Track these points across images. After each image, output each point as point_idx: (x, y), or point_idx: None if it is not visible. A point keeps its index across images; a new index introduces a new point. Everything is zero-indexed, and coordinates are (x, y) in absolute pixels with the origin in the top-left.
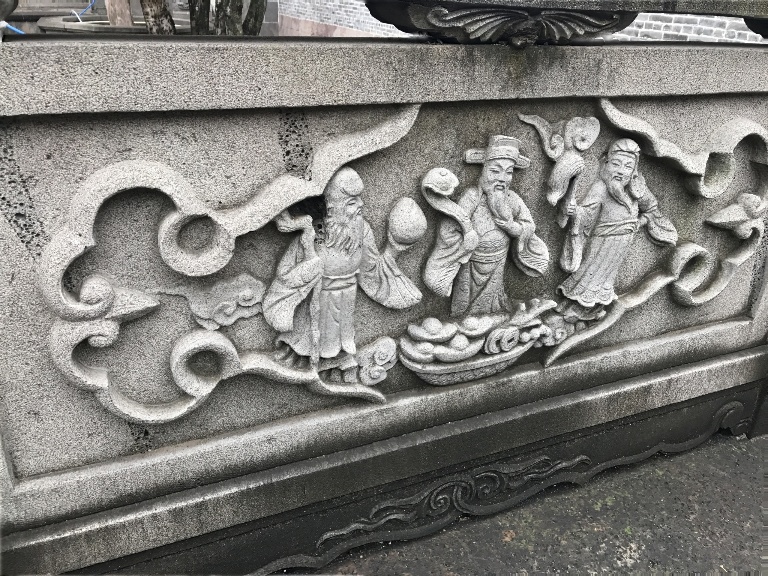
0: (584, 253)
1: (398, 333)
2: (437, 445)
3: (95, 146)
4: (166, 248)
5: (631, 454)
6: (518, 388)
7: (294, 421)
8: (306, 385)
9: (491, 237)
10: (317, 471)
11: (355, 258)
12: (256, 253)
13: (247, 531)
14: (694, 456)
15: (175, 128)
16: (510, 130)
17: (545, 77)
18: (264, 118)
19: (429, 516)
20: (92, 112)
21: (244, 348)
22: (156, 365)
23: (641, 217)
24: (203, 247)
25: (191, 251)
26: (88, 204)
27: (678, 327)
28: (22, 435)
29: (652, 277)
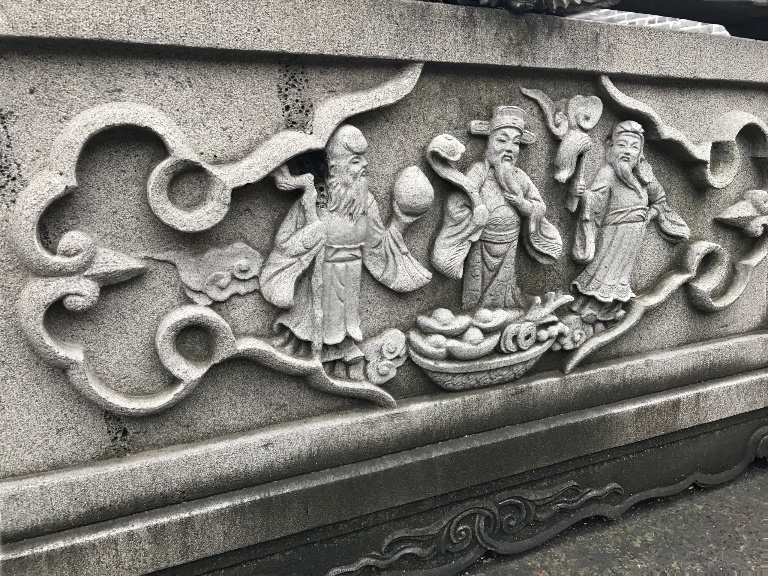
0: (596, 245)
1: (407, 326)
2: (455, 459)
3: (83, 83)
4: (156, 195)
5: (665, 484)
6: (538, 397)
7: (294, 425)
8: (308, 378)
9: (501, 213)
10: (321, 484)
11: (360, 226)
12: (253, 219)
13: (240, 562)
14: (733, 489)
15: (169, 70)
16: (513, 104)
17: (545, 46)
18: (263, 68)
19: (449, 553)
20: (81, 38)
21: (239, 332)
22: (139, 346)
23: (651, 209)
24: (196, 205)
25: (183, 208)
26: (72, 140)
27: (699, 338)
28: None
29: (668, 276)
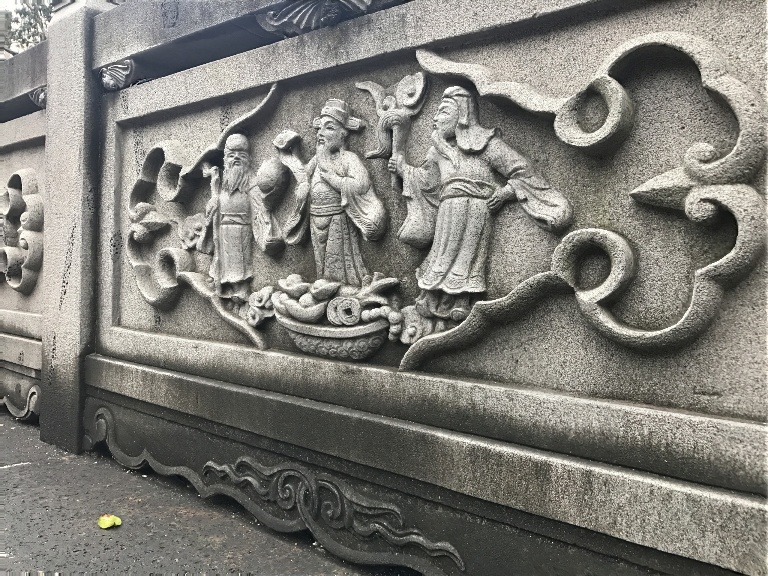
0: None
1: None
2: (280, 408)
3: None
4: (159, 182)
5: None
6: (369, 386)
7: None
8: None
9: (317, 188)
10: (205, 384)
11: (235, 200)
12: None
13: (172, 420)
14: None
15: None
16: (352, 99)
17: (357, 43)
18: (215, 110)
19: None
20: (153, 112)
21: (199, 270)
22: None
23: None
24: None
25: None
26: None
27: (642, 397)
28: (125, 298)
29: None
